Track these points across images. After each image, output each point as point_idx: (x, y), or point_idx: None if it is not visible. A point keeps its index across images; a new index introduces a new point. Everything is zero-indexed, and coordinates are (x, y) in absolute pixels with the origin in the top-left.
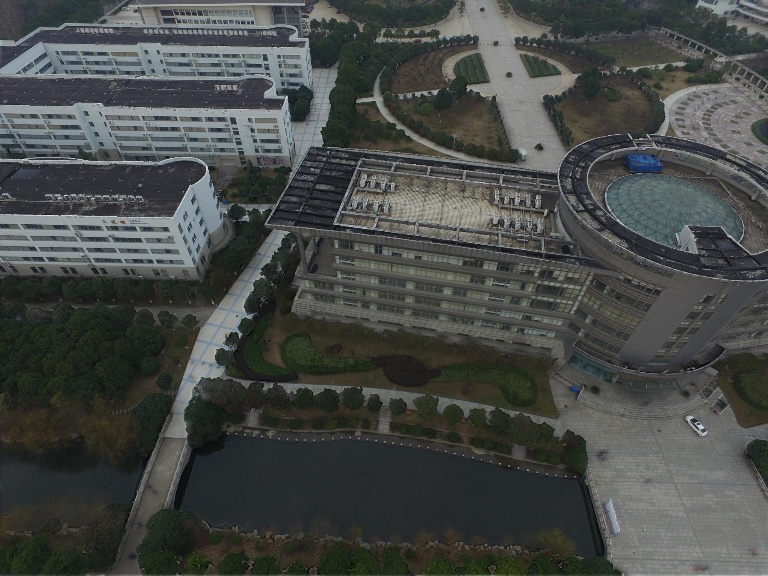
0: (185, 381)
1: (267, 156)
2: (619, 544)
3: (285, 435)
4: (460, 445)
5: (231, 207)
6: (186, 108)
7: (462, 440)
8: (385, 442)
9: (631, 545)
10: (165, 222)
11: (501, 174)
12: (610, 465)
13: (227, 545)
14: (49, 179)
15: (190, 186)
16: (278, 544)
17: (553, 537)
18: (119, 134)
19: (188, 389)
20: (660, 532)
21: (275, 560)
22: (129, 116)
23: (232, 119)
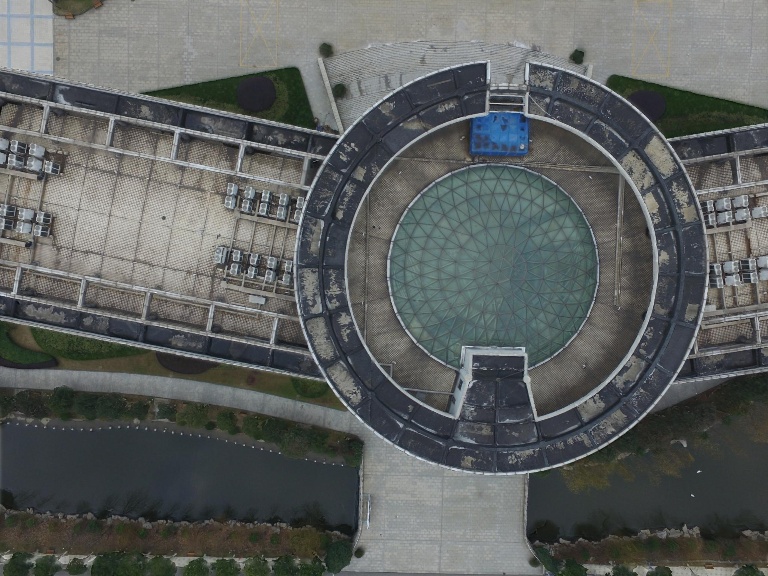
0: None
1: None
2: (370, 528)
3: (61, 423)
4: (242, 434)
5: None
6: None
7: (243, 432)
8: (165, 431)
9: (380, 529)
10: None
11: (242, 140)
12: (386, 460)
13: (22, 529)
14: None
15: None
16: (70, 523)
17: (299, 545)
18: None
19: None
20: (411, 519)
21: (54, 560)
22: None
23: None
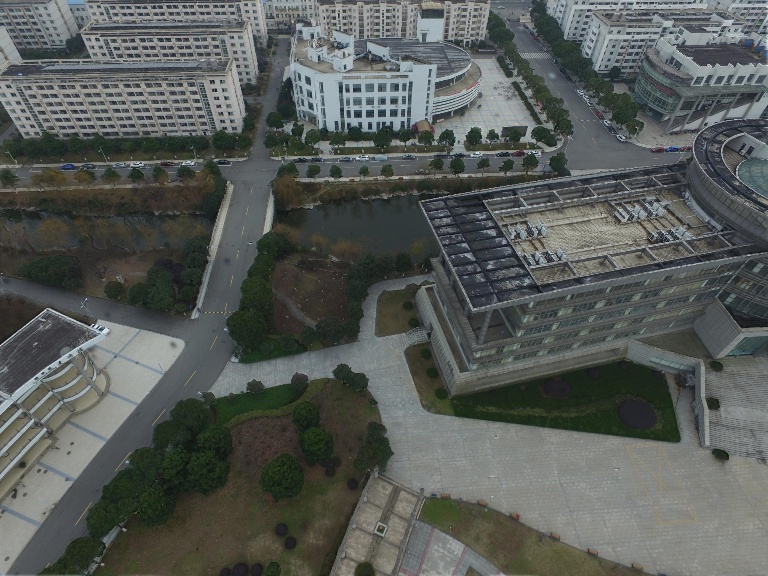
0: None
1: None
2: None
3: None
4: None
5: None
6: None
7: None
8: None
9: None
10: None
11: None
12: None
13: None
14: None
15: None
16: None
17: None
18: None
19: None
20: None
21: None
22: None
23: None
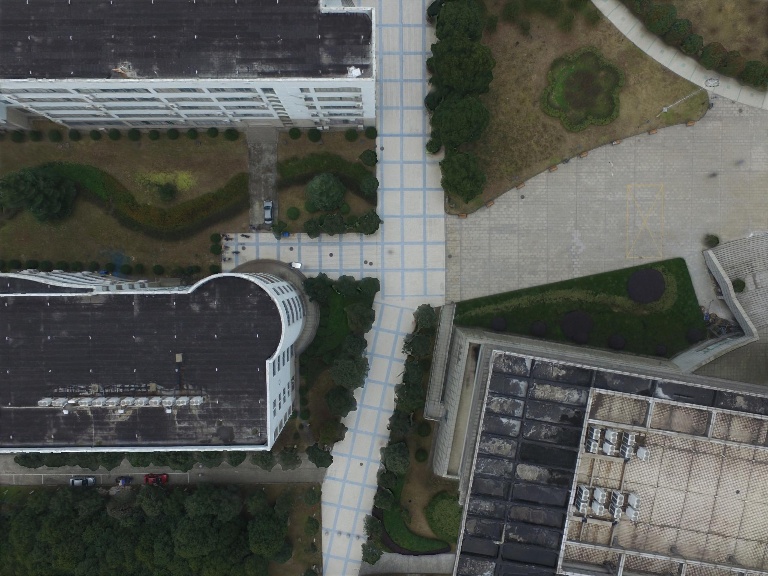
0: (326, 557)
1: (333, 118)
2: None
3: None
4: None
5: (310, 290)
6: (164, 80)
7: None
8: None
9: None
10: (255, 445)
11: None
12: None
13: None
14: (12, 341)
15: (268, 365)
16: None
17: None
18: (37, 104)
19: (333, 567)
20: None
21: None
22: (45, 88)
23: (265, 88)
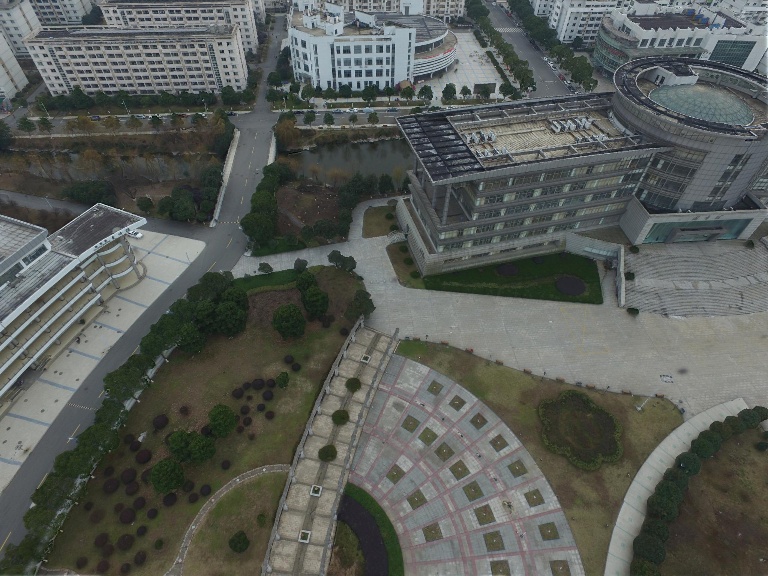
0: None
1: None
2: None
3: None
4: None
5: None
6: None
7: None
8: None
9: None
10: None
11: None
12: None
13: None
14: None
15: None
16: None
17: None
18: None
19: None
20: None
21: None
22: None
23: None
